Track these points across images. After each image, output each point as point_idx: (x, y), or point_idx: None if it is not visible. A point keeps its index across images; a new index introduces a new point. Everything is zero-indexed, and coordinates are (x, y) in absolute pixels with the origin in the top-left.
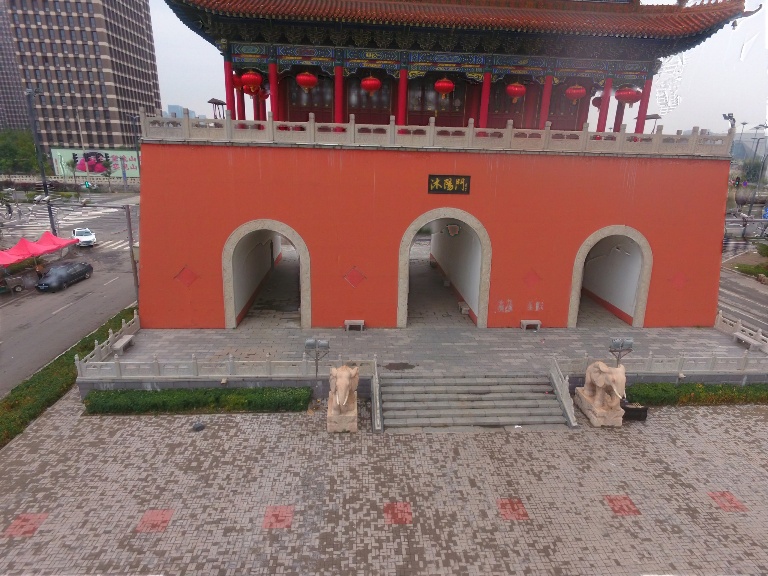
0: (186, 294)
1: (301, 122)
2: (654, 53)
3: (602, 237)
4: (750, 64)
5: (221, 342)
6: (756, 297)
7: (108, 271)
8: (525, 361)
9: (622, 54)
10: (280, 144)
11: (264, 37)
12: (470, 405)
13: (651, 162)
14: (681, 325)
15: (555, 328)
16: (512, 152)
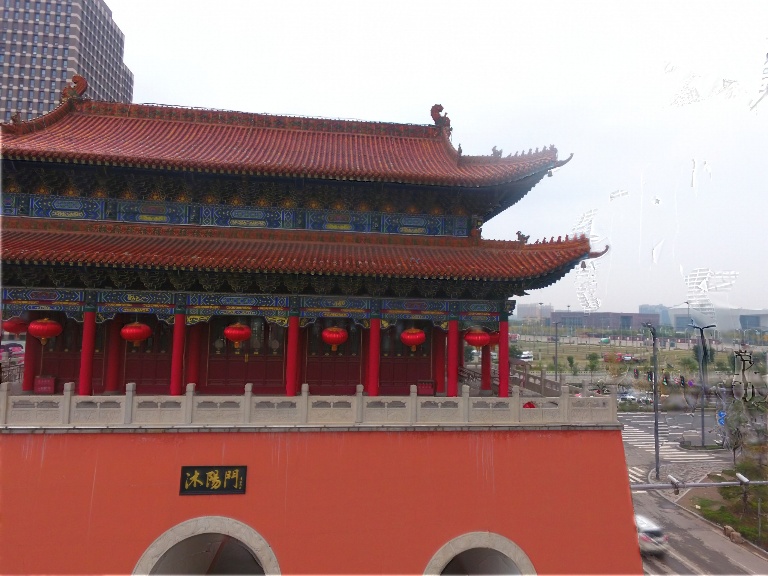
0: None
1: None
2: (502, 292)
3: (456, 552)
4: (663, 266)
5: None
6: (726, 575)
7: None
8: None
9: (464, 293)
10: None
11: None
12: None
13: (512, 436)
14: None
15: None
16: (308, 429)
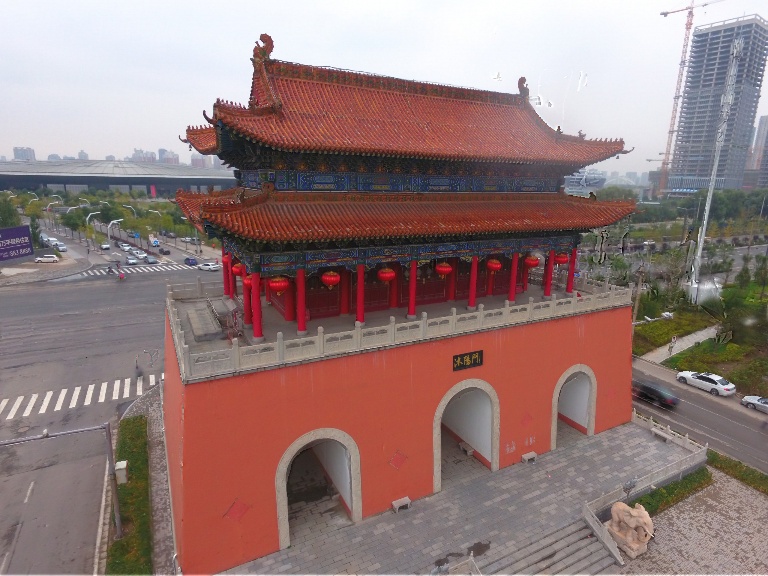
0: (237, 529)
1: (348, 331)
2: (578, 230)
3: (568, 376)
4: None
5: (295, 575)
6: None
7: (8, 474)
8: (556, 506)
9: None
10: (331, 356)
11: (293, 245)
12: (551, 573)
13: (591, 315)
14: (614, 425)
15: (544, 454)
16: (510, 326)
